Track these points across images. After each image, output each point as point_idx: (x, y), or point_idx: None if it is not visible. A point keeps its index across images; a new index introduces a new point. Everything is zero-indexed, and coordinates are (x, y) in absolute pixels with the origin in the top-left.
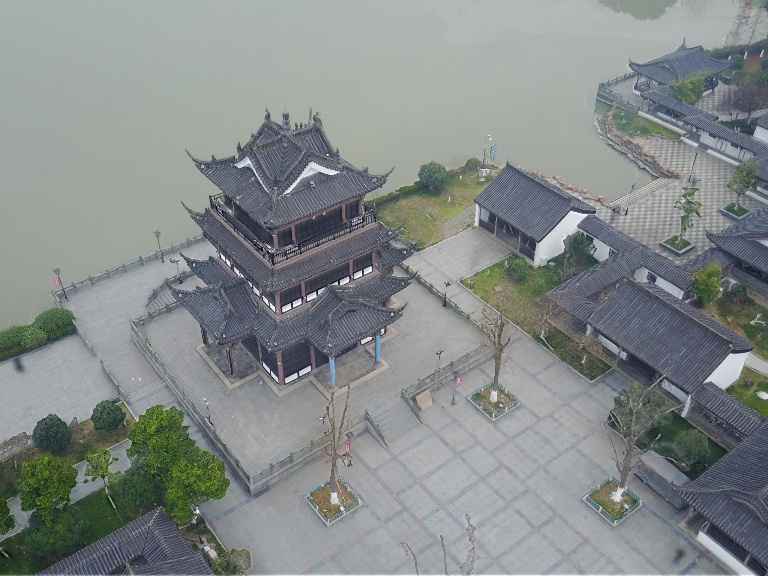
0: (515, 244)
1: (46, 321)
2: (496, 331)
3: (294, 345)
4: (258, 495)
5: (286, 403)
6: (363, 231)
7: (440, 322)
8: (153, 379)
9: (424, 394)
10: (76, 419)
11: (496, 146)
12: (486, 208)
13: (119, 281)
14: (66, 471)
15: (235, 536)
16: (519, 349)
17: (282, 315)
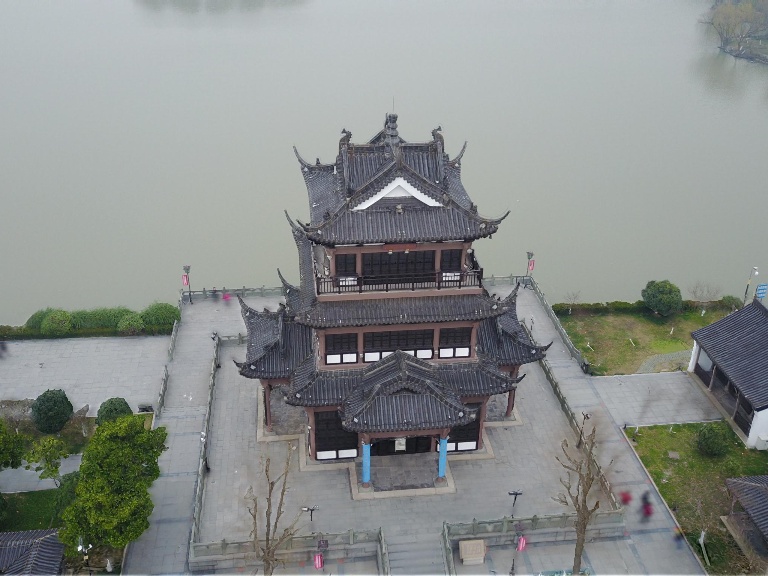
0: (733, 409)
1: (150, 312)
2: (580, 483)
3: (334, 411)
4: (197, 573)
5: (303, 481)
6: (459, 293)
7: (559, 464)
8: (202, 403)
9: (474, 542)
10: (88, 407)
11: (767, 285)
12: (702, 347)
13: (250, 302)
14: None
15: None
16: (656, 543)
17: (325, 366)
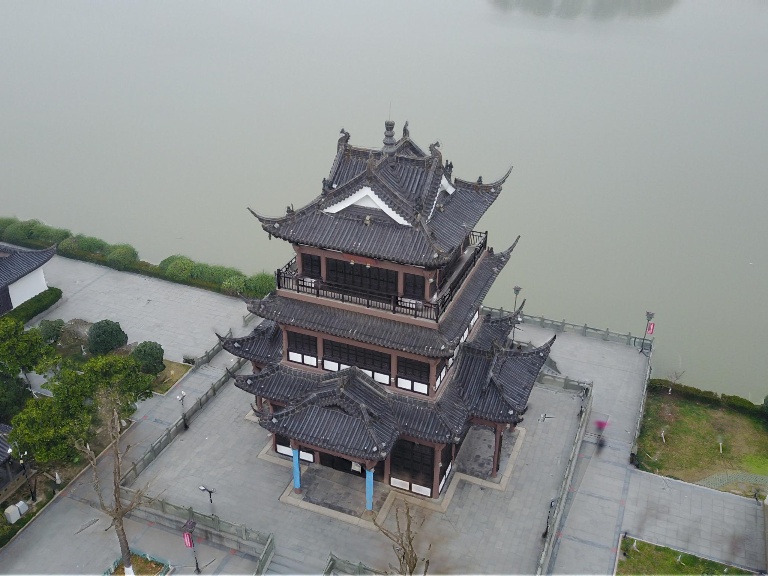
0: None
1: (253, 279)
2: None
3: None
4: None
5: (252, 467)
6: (415, 323)
7: (508, 544)
8: None
9: None
10: (136, 344)
11: None
12: None
13: None
14: (21, 347)
15: (52, 521)
16: None
17: (288, 361)
